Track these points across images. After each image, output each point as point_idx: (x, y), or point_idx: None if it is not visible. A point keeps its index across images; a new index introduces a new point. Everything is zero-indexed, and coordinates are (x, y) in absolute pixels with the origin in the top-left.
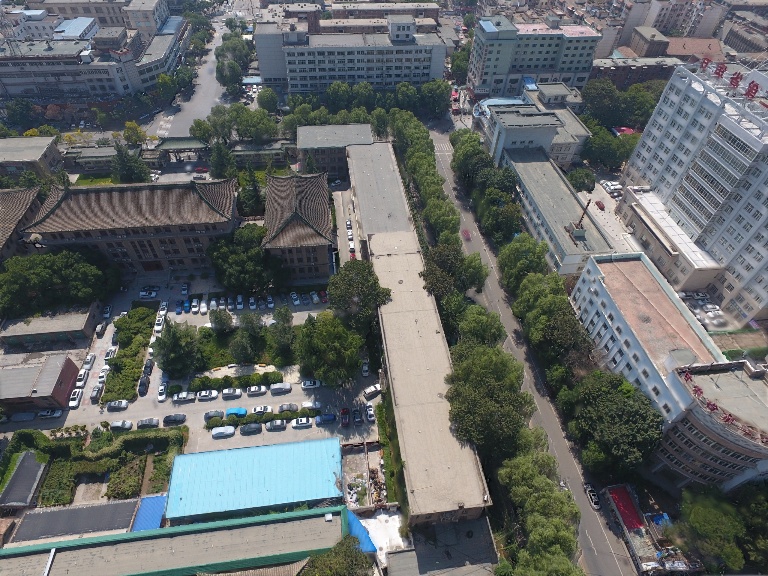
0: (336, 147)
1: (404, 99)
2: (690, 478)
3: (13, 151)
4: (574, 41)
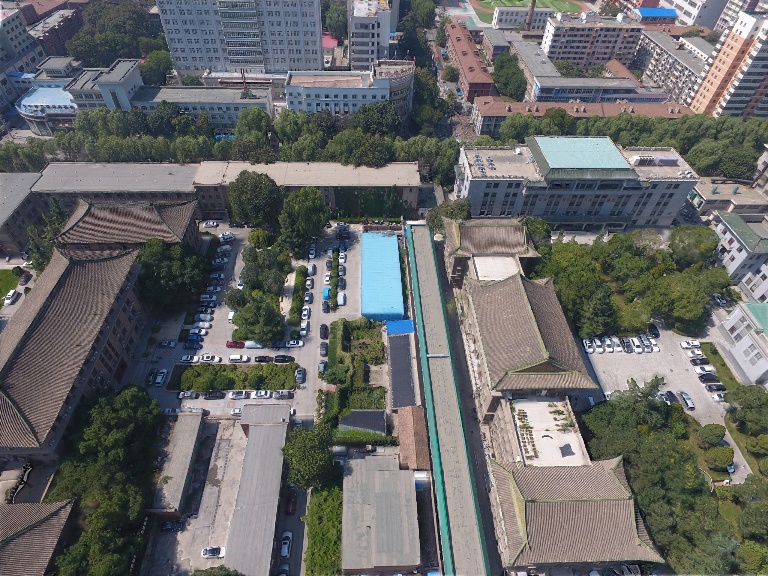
0: (25, 198)
1: None
2: (404, 119)
3: None
4: (6, 24)
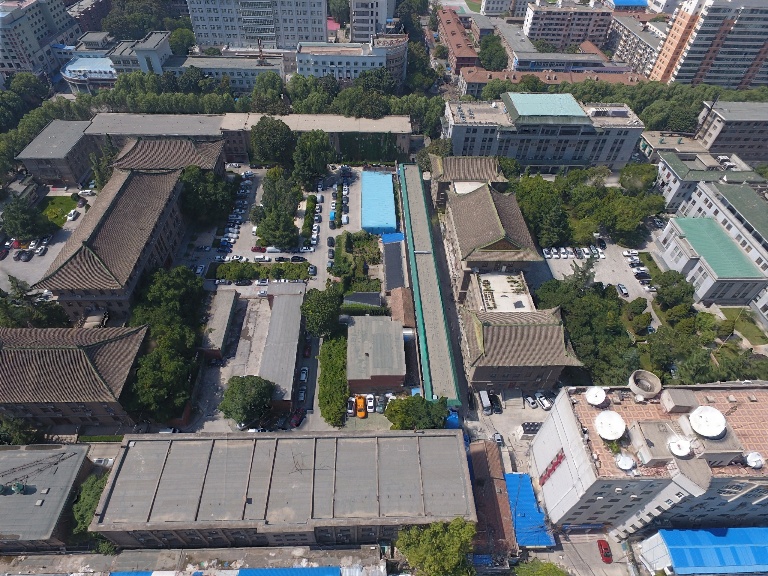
0: (80, 139)
1: (17, 103)
2: (399, 85)
3: None
4: (50, 2)
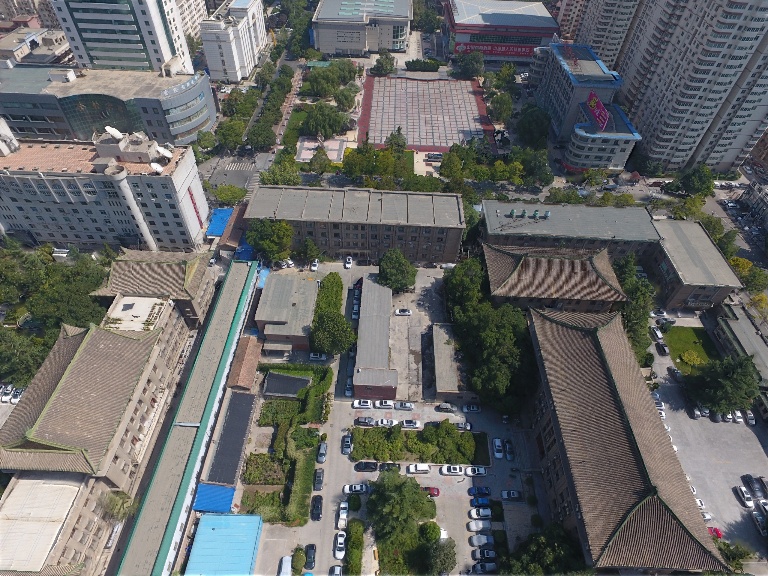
0: None
1: None
2: None
3: (692, 259)
4: None
